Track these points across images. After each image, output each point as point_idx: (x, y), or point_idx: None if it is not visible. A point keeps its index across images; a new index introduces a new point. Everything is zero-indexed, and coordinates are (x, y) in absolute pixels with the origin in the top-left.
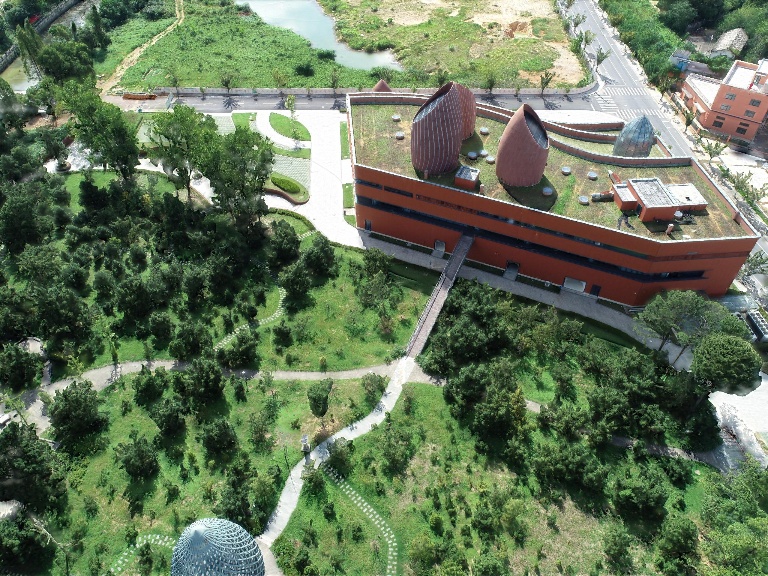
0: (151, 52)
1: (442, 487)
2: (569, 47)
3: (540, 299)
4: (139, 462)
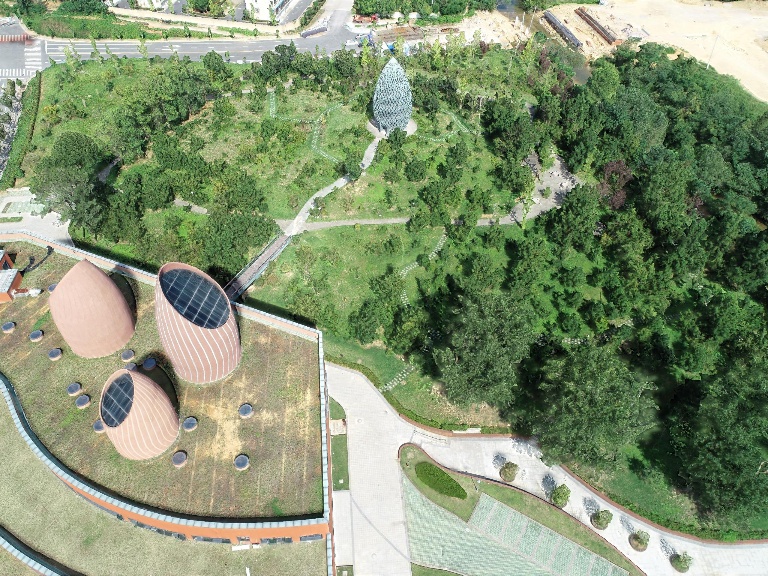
0: None
1: None
2: None
3: None
4: None
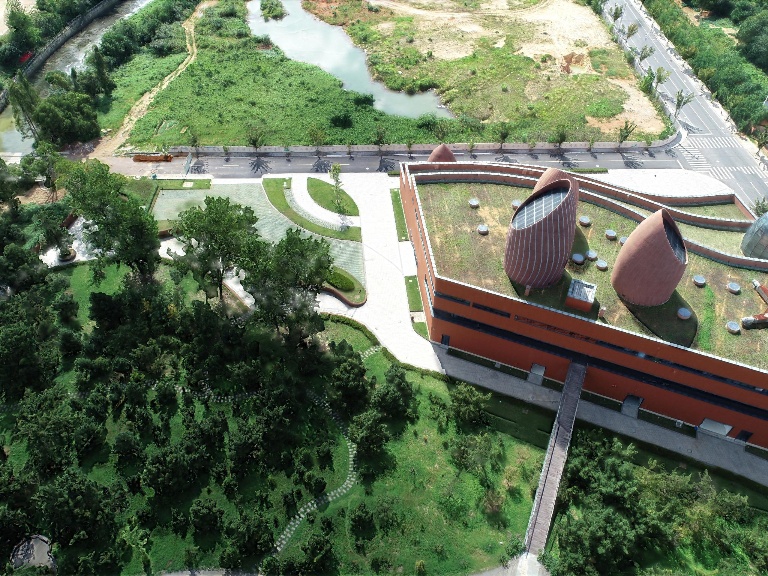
0: (162, 99)
1: None
2: (637, 85)
3: (674, 447)
4: None
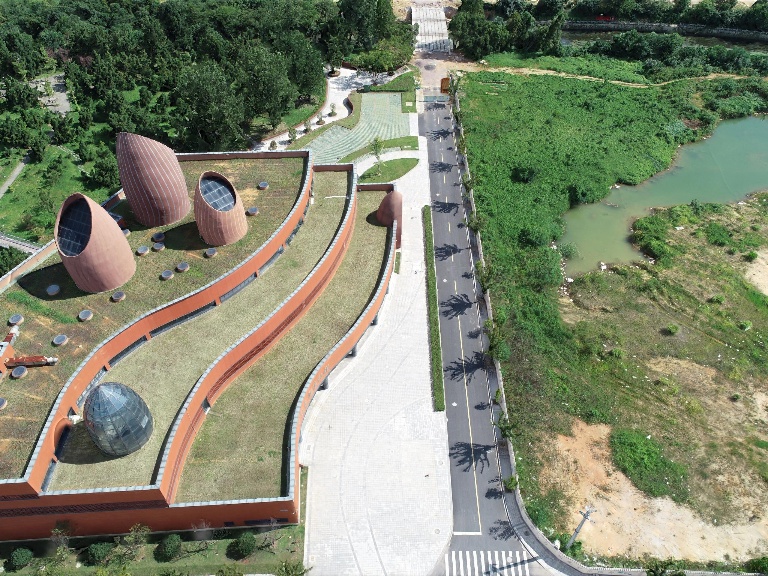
0: (542, 78)
1: None
2: None
3: None
4: None
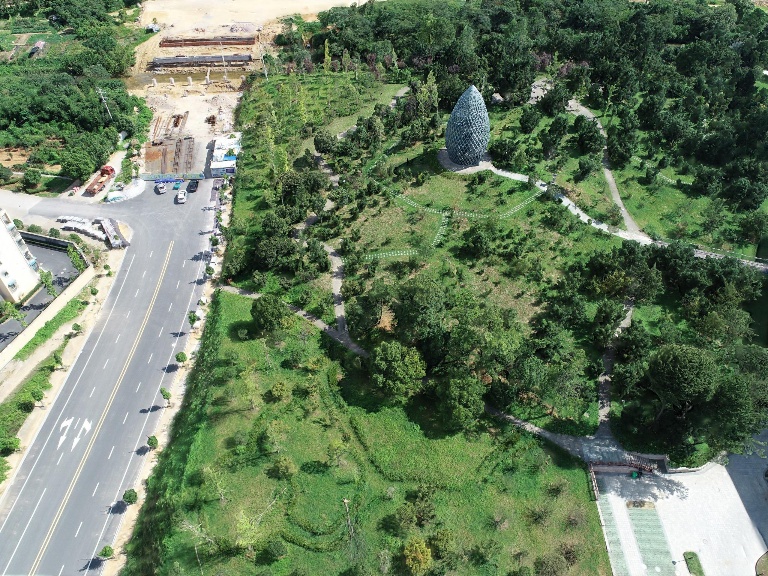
0: None
1: (538, 243)
2: None
3: None
4: (526, 118)
